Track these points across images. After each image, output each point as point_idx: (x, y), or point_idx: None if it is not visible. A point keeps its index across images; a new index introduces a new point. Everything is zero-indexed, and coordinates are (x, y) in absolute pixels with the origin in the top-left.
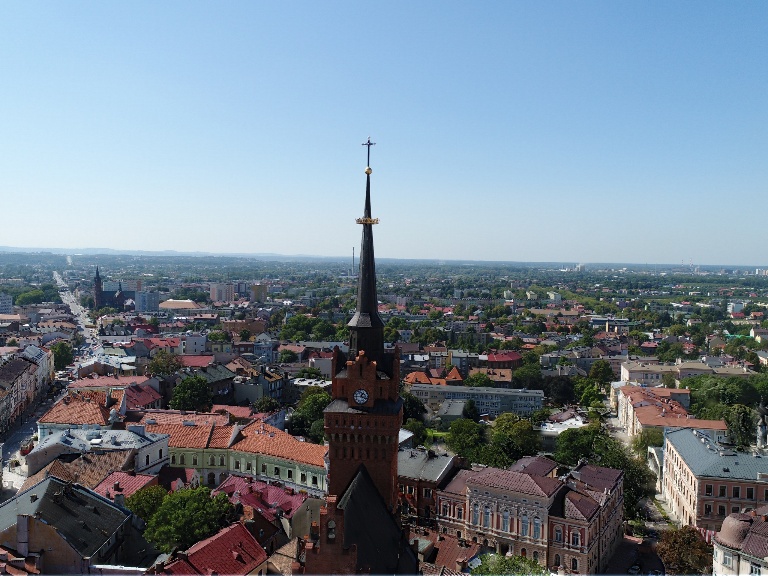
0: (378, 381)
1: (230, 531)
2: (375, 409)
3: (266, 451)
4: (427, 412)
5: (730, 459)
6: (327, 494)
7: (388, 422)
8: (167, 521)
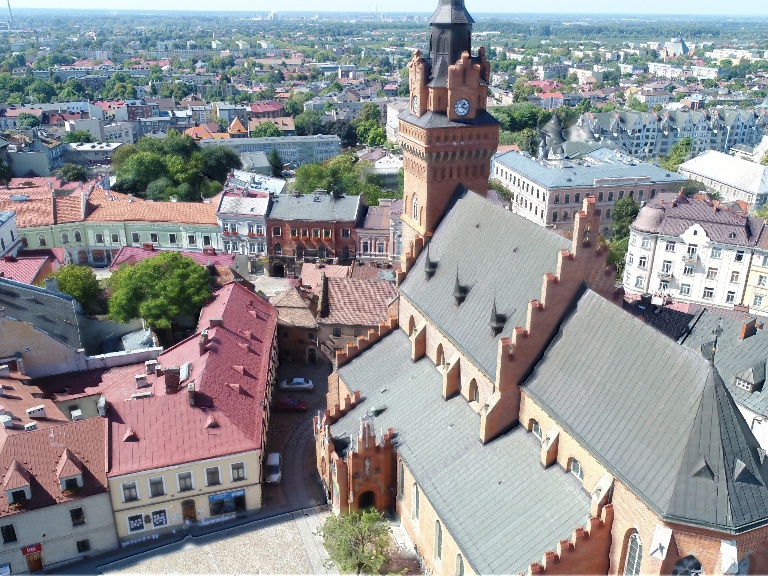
0: (477, 88)
1: (232, 292)
2: (477, 120)
3: (136, 217)
4: (242, 165)
5: (569, 171)
6: (224, 253)
7: (491, 134)
8: (138, 296)
